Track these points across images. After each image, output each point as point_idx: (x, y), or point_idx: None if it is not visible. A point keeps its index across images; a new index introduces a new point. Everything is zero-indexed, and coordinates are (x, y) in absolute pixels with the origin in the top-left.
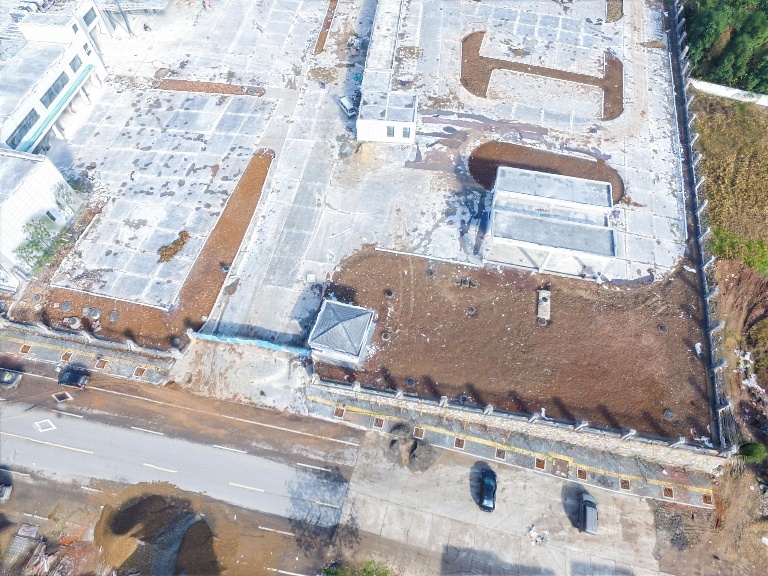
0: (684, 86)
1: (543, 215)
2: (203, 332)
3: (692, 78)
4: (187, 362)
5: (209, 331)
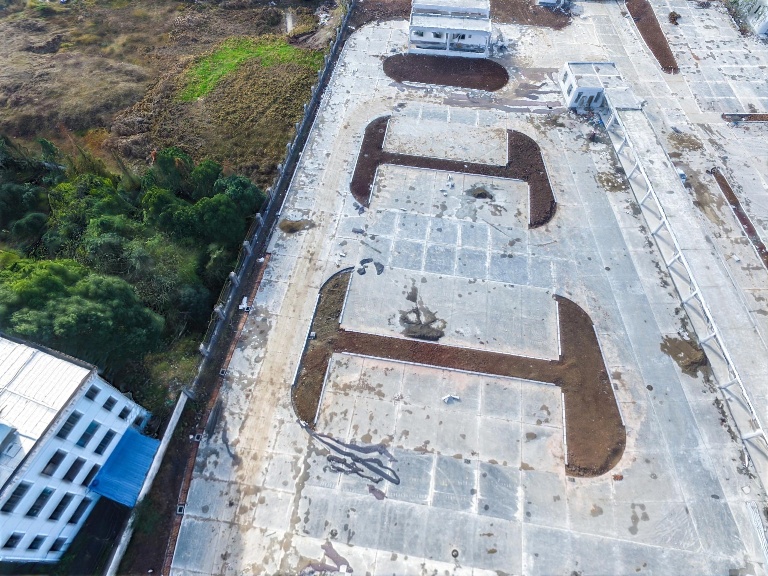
0: None
1: None
2: None
3: None
4: None
5: (620, 1)
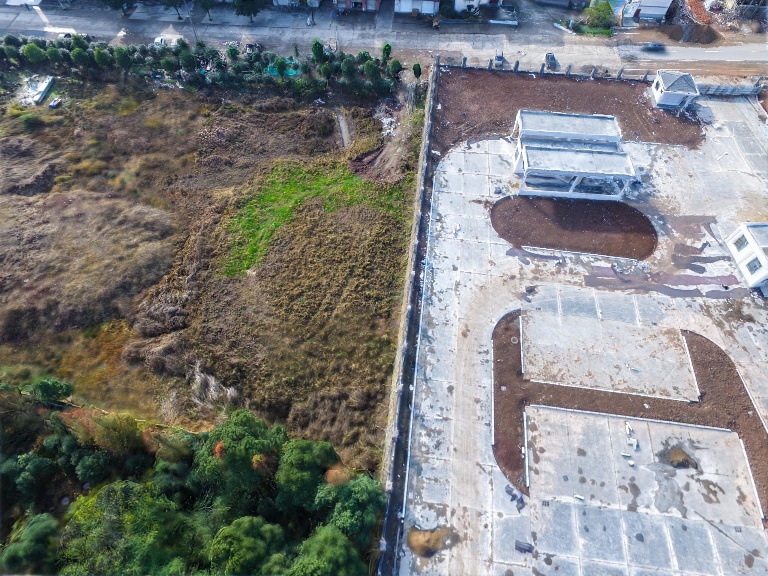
0: None
1: None
2: (754, 97)
3: (359, 470)
4: (747, 85)
5: (751, 98)
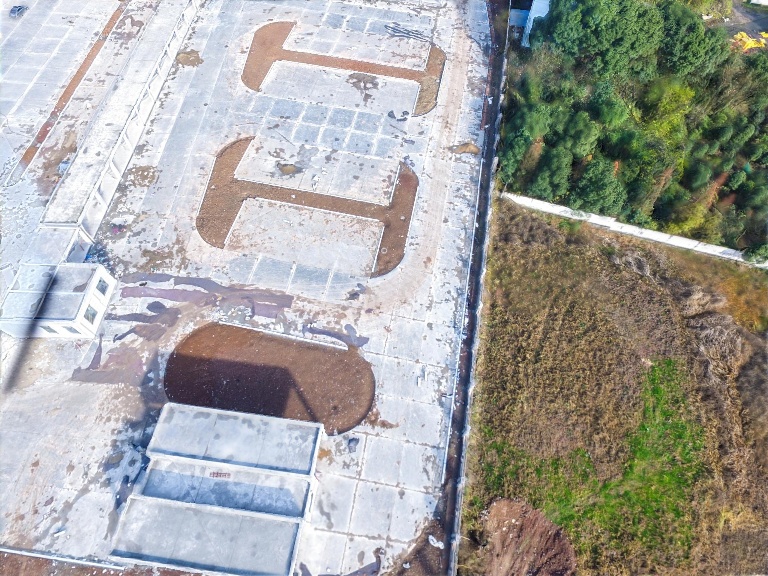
0: (486, 216)
1: (218, 485)
2: None
3: (510, 192)
4: None
5: None
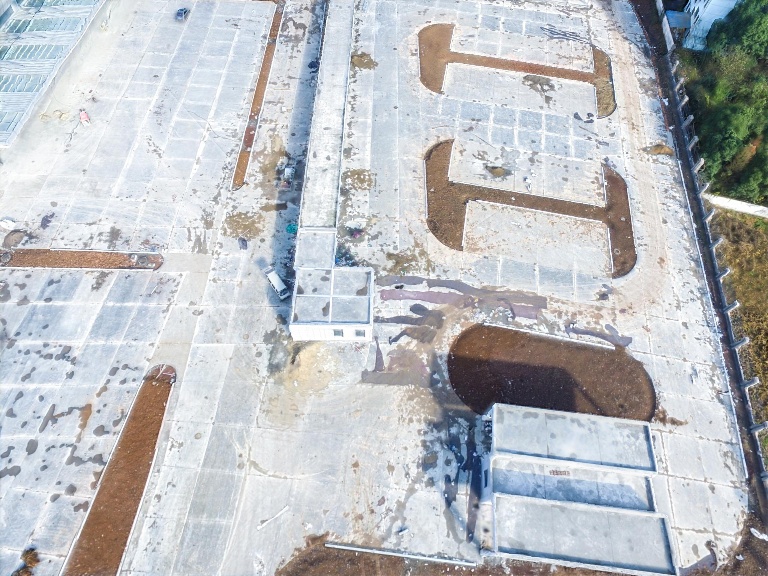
0: (705, 217)
1: (561, 482)
2: None
3: (707, 193)
4: None
5: None
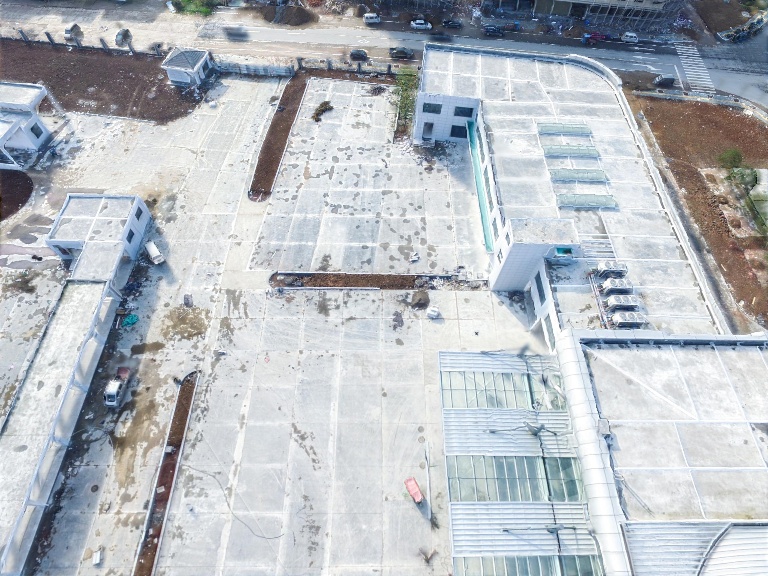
0: None
1: None
2: None
3: None
4: (295, 67)
5: (285, 79)
